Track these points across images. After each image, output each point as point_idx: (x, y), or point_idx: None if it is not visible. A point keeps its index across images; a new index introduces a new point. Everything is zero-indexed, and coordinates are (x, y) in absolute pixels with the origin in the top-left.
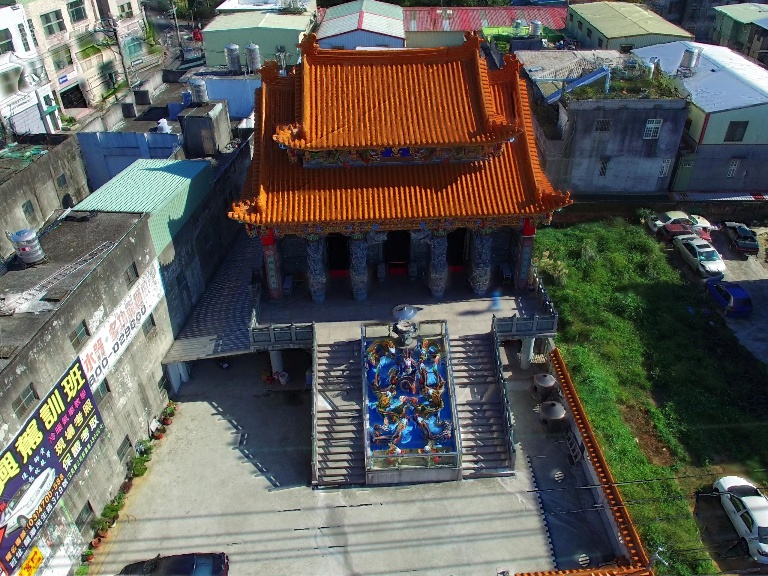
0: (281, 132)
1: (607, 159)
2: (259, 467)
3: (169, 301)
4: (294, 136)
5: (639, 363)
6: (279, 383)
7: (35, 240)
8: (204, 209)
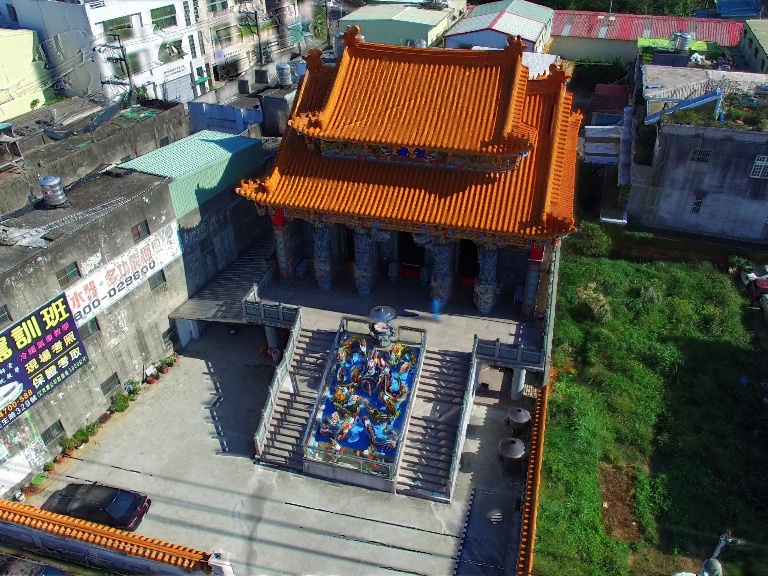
0: (297, 118)
1: (702, 194)
2: (219, 430)
3: (187, 262)
4: (311, 124)
5: (650, 424)
6: (271, 358)
7: (57, 186)
8: None
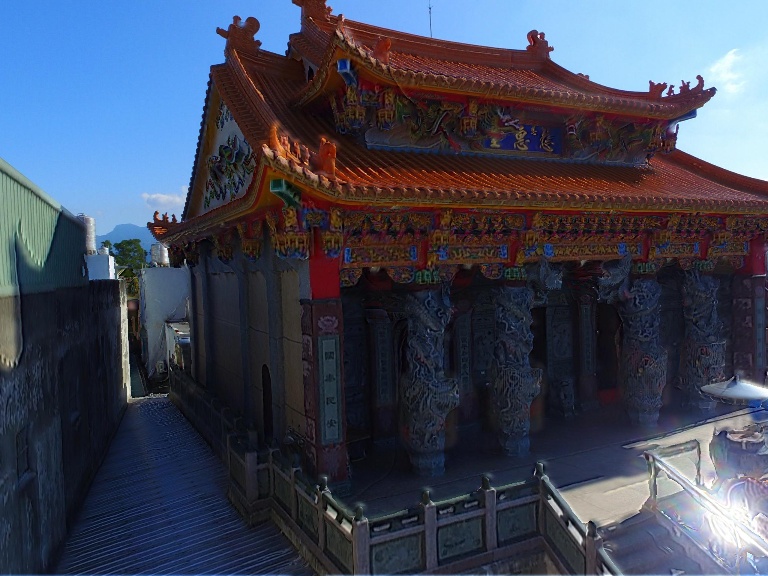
0: None
1: None
2: None
3: None
4: None
5: None
6: None
7: None
8: (72, 315)
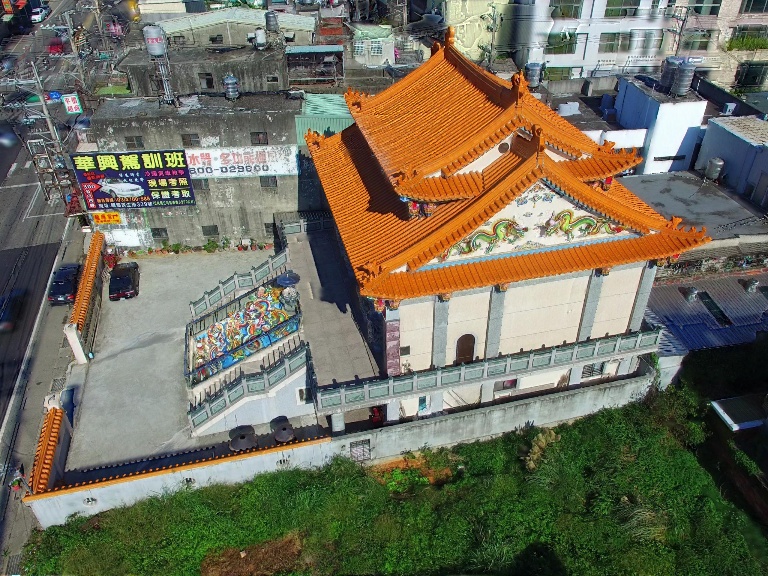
0: (352, 94)
1: None
2: None
3: (303, 183)
4: None
5: (377, 568)
6: None
7: (230, 85)
8: None
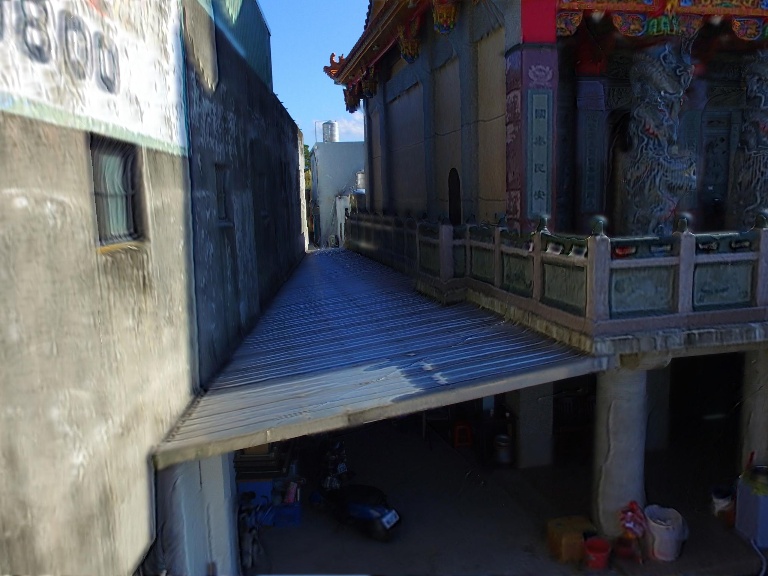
0: None
1: None
2: None
3: (194, 211)
4: None
5: None
6: (648, 556)
7: None
8: None
